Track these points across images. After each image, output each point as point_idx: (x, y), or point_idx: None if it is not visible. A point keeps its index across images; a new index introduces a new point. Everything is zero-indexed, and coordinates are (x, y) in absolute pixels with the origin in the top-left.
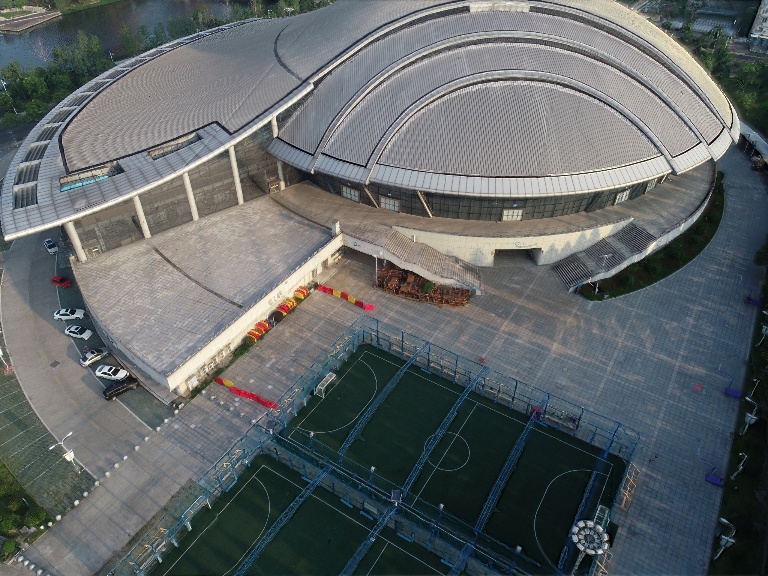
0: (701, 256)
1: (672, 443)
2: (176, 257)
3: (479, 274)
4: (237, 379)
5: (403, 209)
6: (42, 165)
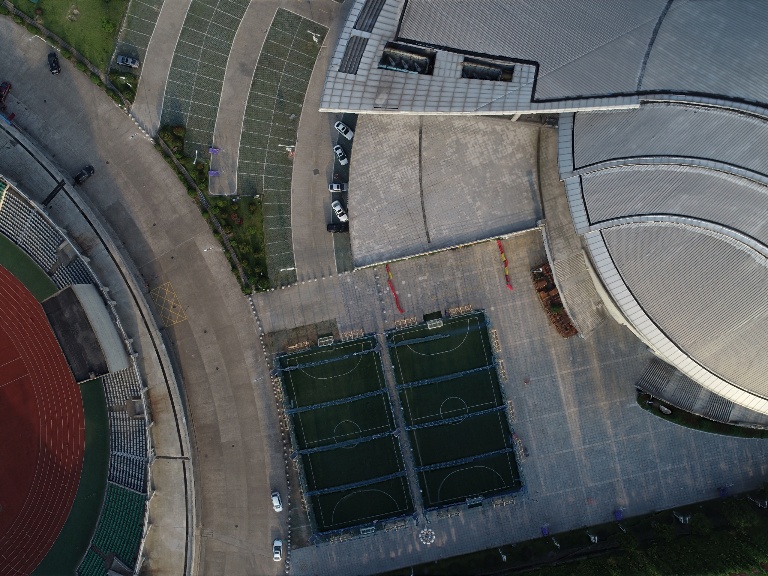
0: (756, 441)
1: (553, 504)
2: (427, 152)
3: (603, 321)
4: (398, 274)
5: None
6: (385, 7)
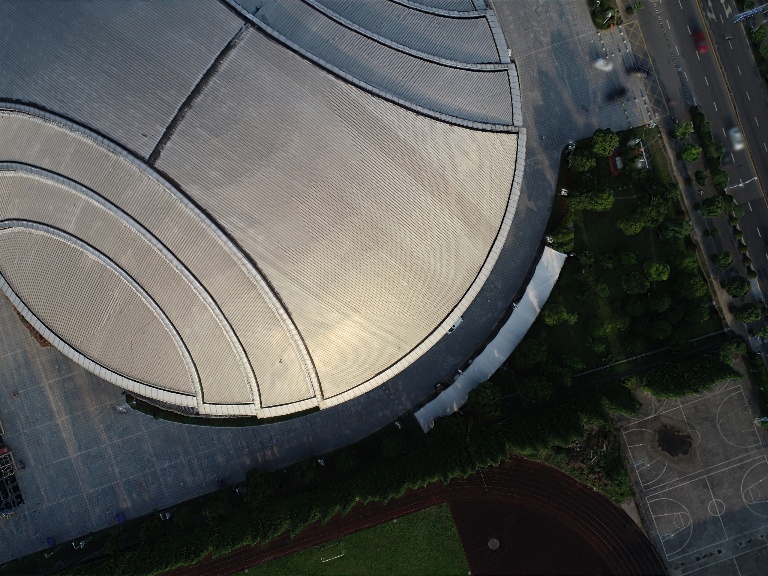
0: (249, 429)
1: (56, 513)
2: None
3: None
4: None
5: None
6: None
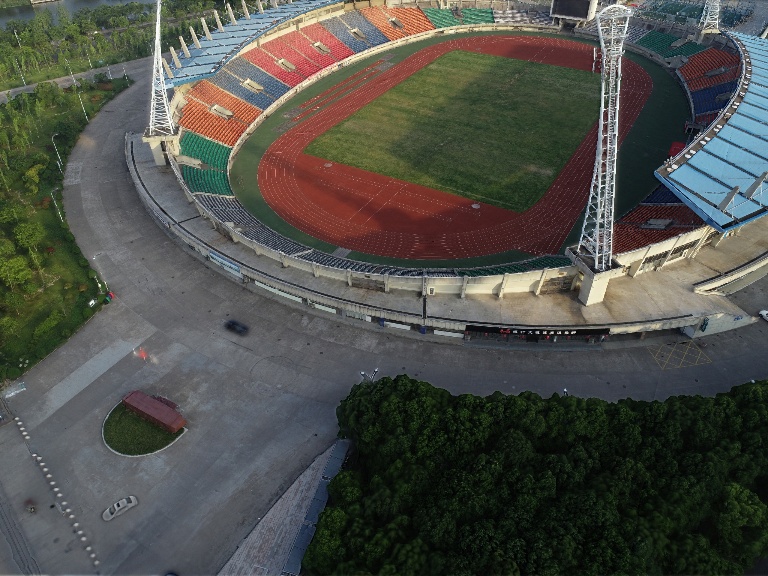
0: None
1: None
2: None
3: None
4: None
5: None
6: None
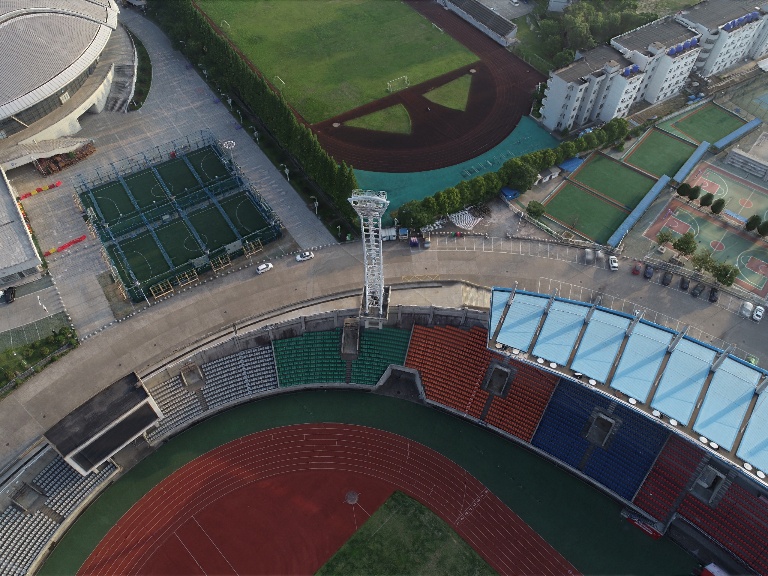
0: (153, 63)
1: (218, 129)
2: None
3: (81, 136)
4: None
5: (9, 134)
6: None
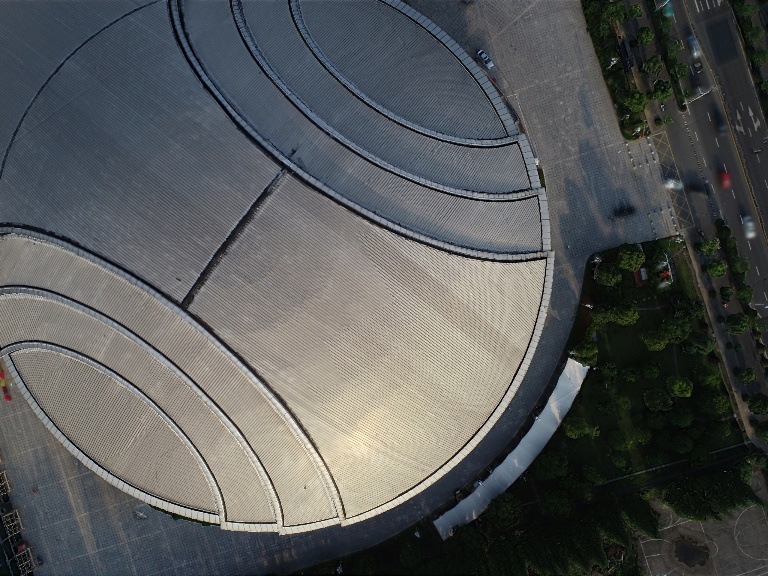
0: None
1: None
2: None
3: None
4: None
5: None
6: None
